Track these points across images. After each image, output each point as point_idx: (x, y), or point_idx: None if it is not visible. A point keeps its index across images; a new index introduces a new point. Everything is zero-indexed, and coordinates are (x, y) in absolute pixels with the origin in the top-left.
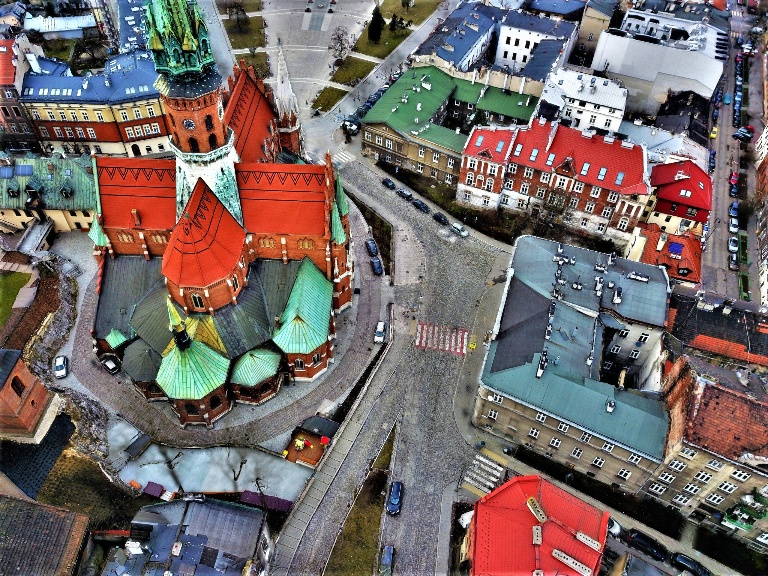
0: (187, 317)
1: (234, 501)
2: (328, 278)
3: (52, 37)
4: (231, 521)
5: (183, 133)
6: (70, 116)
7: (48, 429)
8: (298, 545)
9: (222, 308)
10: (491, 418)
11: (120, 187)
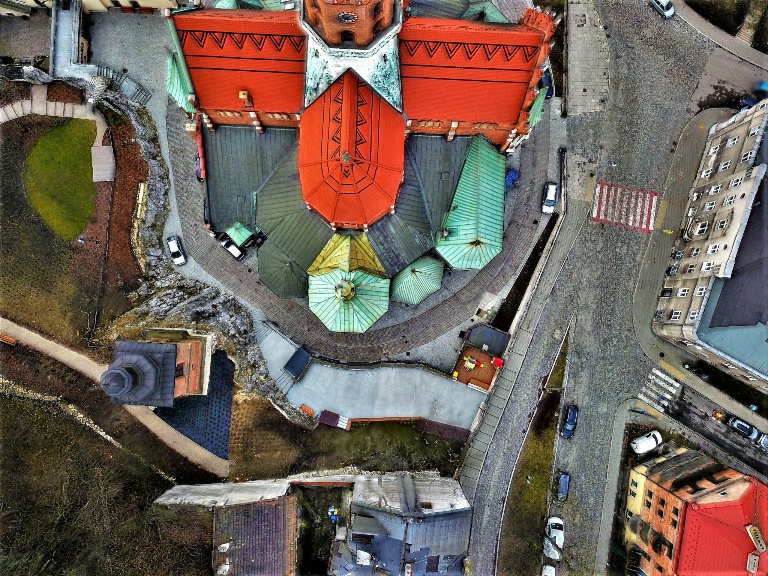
0: (334, 233)
1: (410, 429)
2: (501, 150)
3: None
4: (446, 526)
5: (334, 25)
6: None
7: (209, 373)
8: (479, 476)
9: (377, 221)
10: (683, 342)
11: (217, 58)
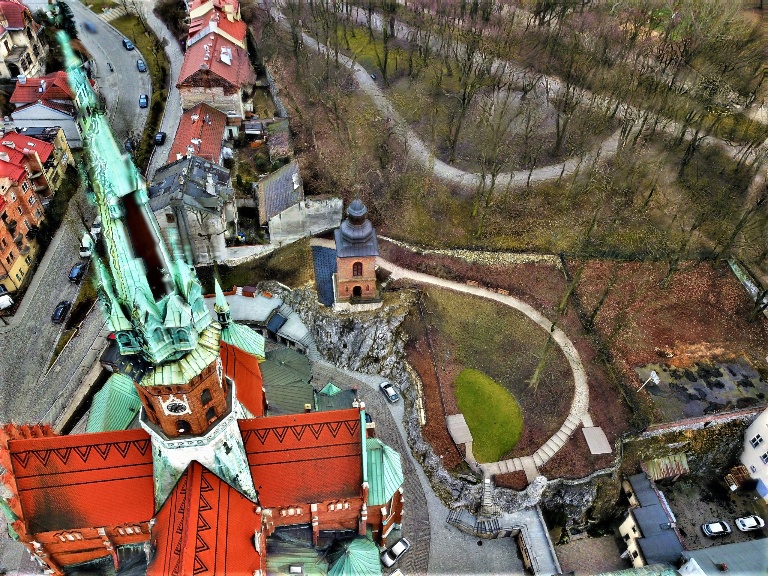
0: None
1: None
2: None
3: None
4: None
5: None
6: None
7: None
8: None
9: None
10: None
11: None
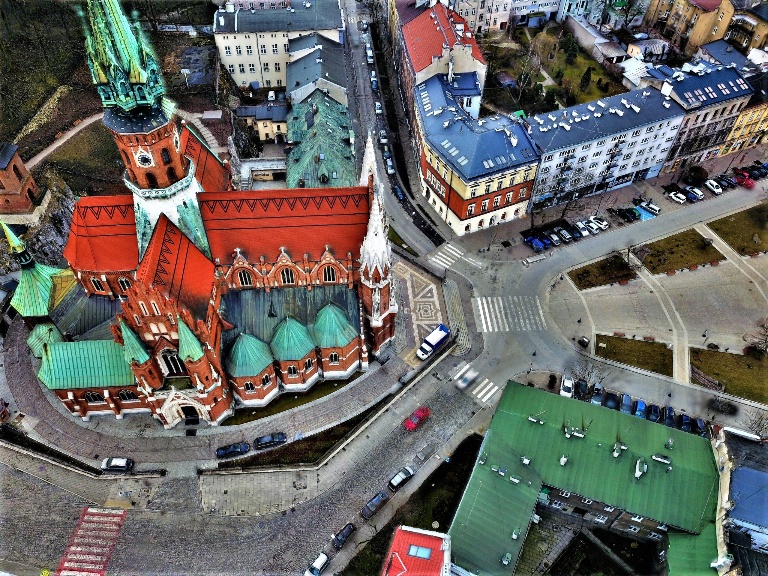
0: None
1: None
2: None
3: (627, 85)
4: None
5: None
6: (420, 126)
7: (11, 223)
8: None
9: None
10: None
11: None
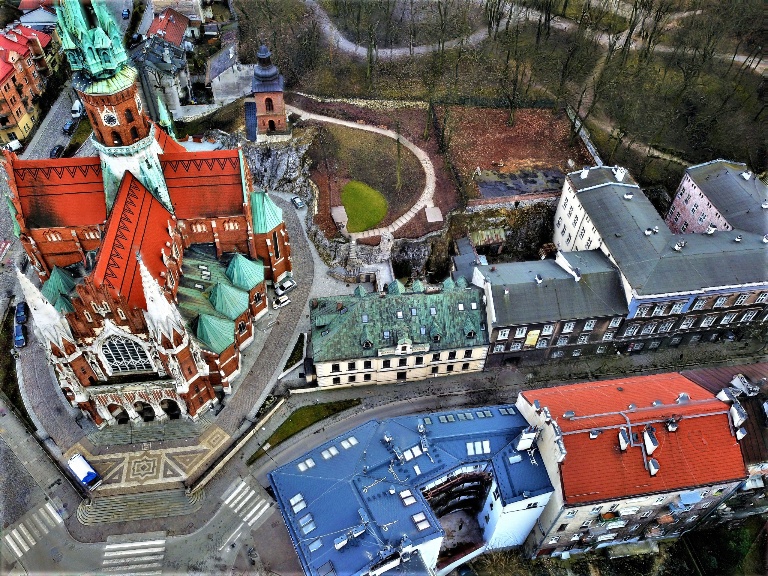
0: None
1: None
2: None
3: None
4: None
5: None
6: None
7: None
8: None
9: None
10: None
11: None
